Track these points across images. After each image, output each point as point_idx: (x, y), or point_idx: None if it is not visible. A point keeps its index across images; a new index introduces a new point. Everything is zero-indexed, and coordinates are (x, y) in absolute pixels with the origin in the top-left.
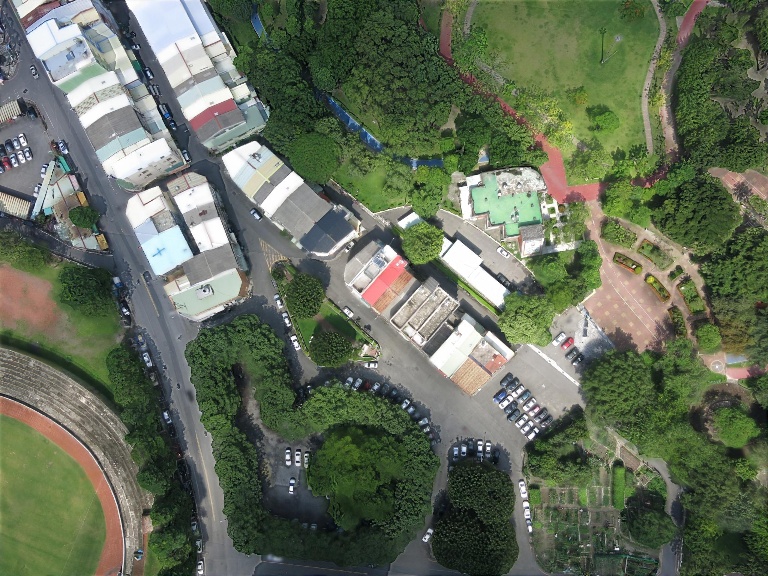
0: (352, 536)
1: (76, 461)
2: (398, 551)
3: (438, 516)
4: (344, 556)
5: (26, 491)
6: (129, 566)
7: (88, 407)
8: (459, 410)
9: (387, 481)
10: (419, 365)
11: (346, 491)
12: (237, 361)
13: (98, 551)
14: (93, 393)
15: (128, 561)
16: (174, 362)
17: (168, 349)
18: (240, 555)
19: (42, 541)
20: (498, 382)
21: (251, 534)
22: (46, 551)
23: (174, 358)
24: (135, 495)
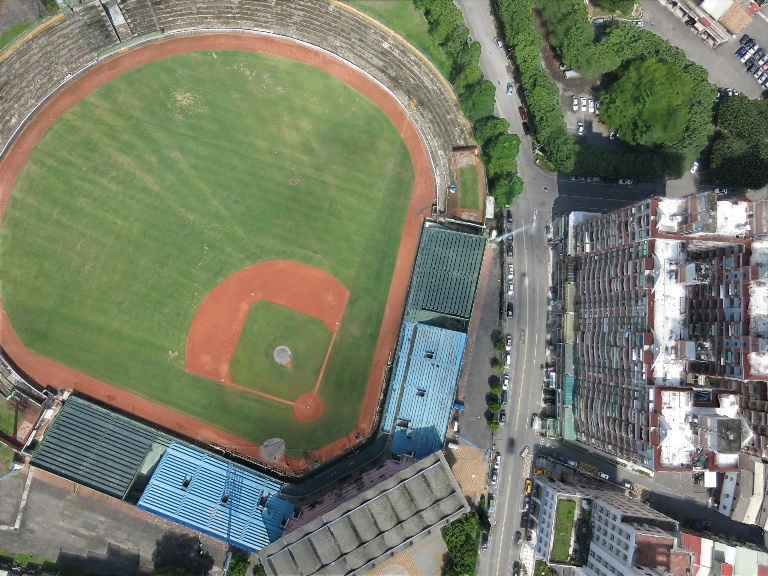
0: (650, 154)
1: (379, 107)
2: (687, 167)
3: (701, 151)
4: (650, 167)
5: (331, 136)
6: (440, 203)
7: (391, 52)
8: (710, 64)
9: (680, 103)
10: (675, 26)
11: (657, 103)
12: (537, 5)
13: (409, 191)
14: (398, 36)
15: (439, 198)
16: (464, 17)
17: (457, 5)
18: (540, 190)
19: (352, 183)
20: (738, 41)
21: (571, 150)
22: (357, 192)
23: (464, 13)
24: (443, 135)
